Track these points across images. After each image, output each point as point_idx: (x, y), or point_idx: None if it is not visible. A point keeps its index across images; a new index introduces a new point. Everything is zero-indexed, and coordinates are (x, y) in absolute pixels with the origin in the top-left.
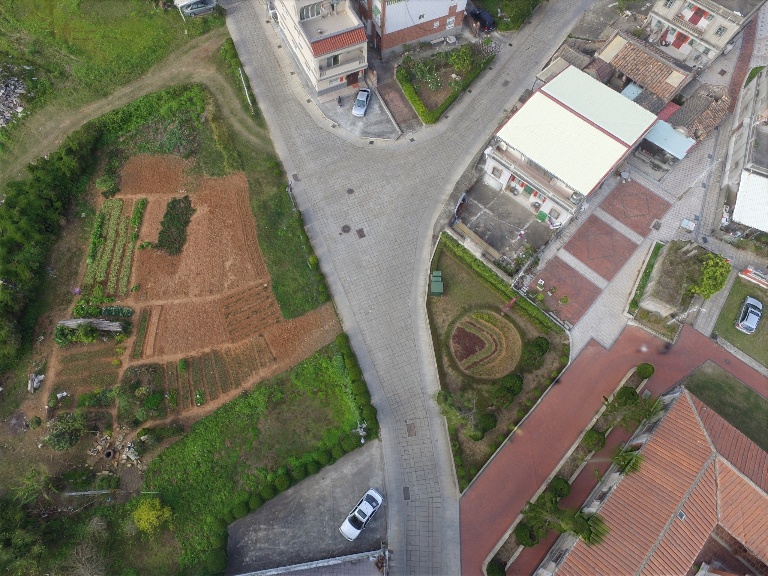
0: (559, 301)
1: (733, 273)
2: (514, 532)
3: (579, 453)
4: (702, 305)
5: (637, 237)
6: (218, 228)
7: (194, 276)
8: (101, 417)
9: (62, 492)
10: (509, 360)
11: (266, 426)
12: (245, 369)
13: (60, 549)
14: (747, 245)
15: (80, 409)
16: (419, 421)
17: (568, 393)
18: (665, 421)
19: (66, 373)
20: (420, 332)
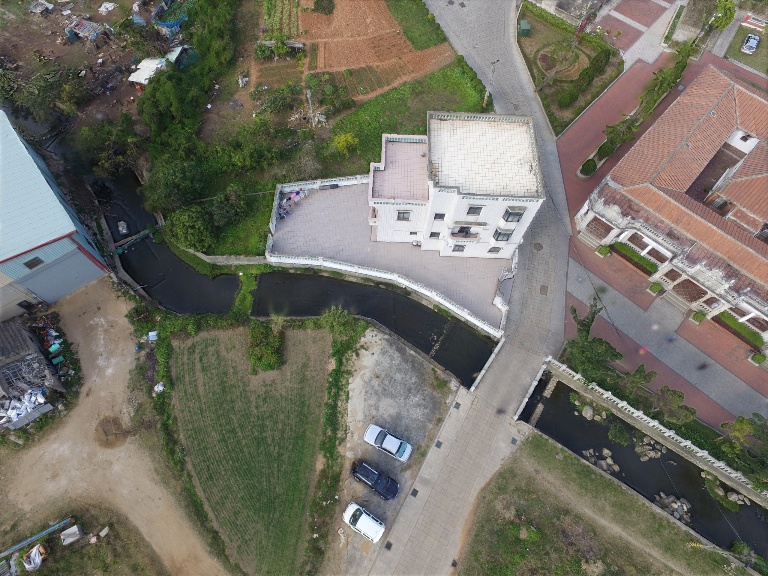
0: (614, 37)
1: (737, 23)
2: (597, 154)
3: (637, 116)
4: (716, 41)
5: (666, 4)
6: (357, 1)
7: (345, 26)
8: (295, 100)
9: (275, 139)
10: (581, 70)
11: (413, 105)
12: (392, 76)
13: (282, 165)
14: (746, 4)
15: (285, 85)
16: (521, 103)
17: (625, 87)
18: (698, 79)
19: (264, 76)
20: (515, 57)
